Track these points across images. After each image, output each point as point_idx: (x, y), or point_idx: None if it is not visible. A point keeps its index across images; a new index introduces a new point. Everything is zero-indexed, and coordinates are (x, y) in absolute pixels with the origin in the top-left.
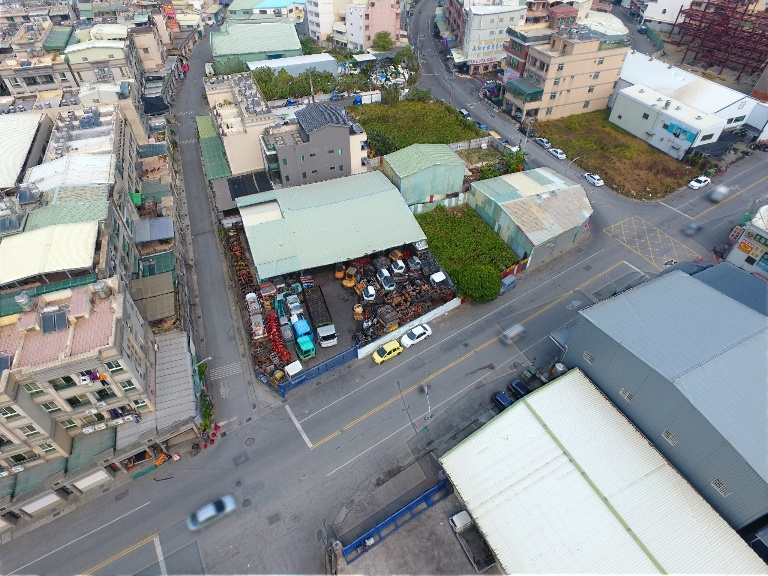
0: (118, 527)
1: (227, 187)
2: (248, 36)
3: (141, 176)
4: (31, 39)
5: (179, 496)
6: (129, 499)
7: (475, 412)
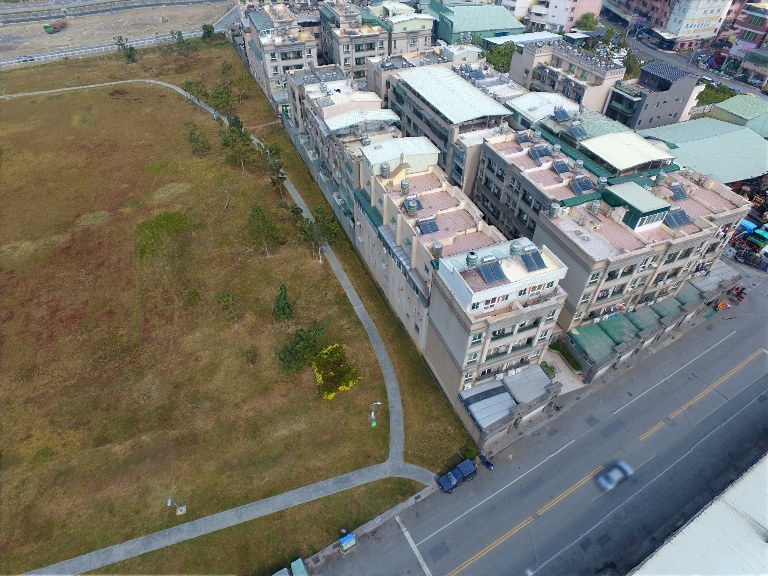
0: (729, 344)
1: None
2: (472, 16)
3: None
4: (353, 12)
5: (754, 327)
6: (718, 329)
7: None
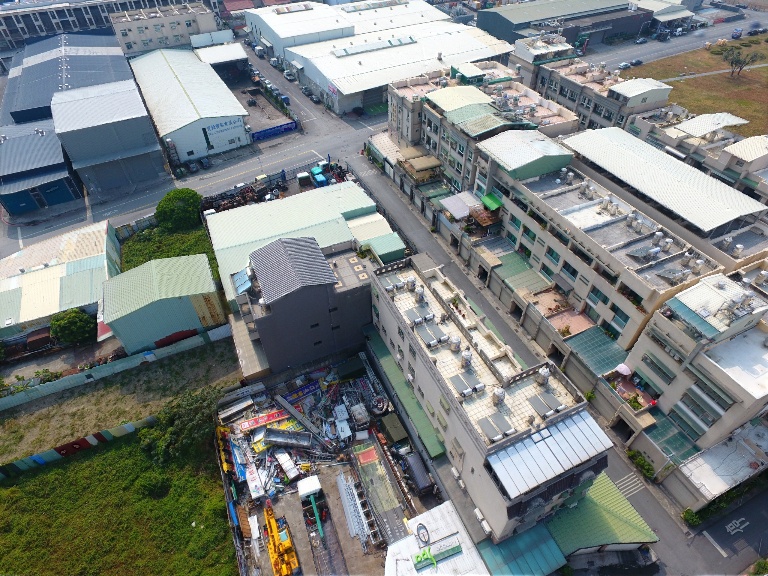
0: None
1: None
2: None
3: (565, 300)
4: None
5: None
6: None
7: None
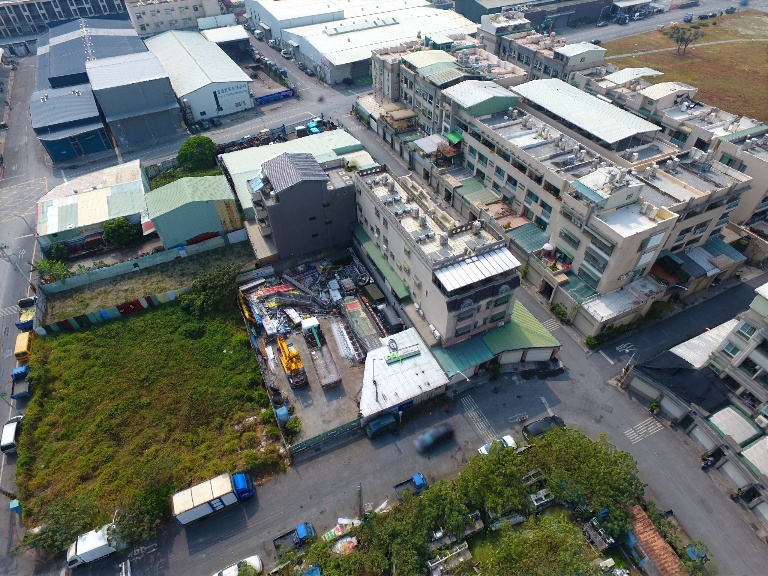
0: None
1: None
2: None
3: (510, 208)
4: None
5: None
6: None
7: None
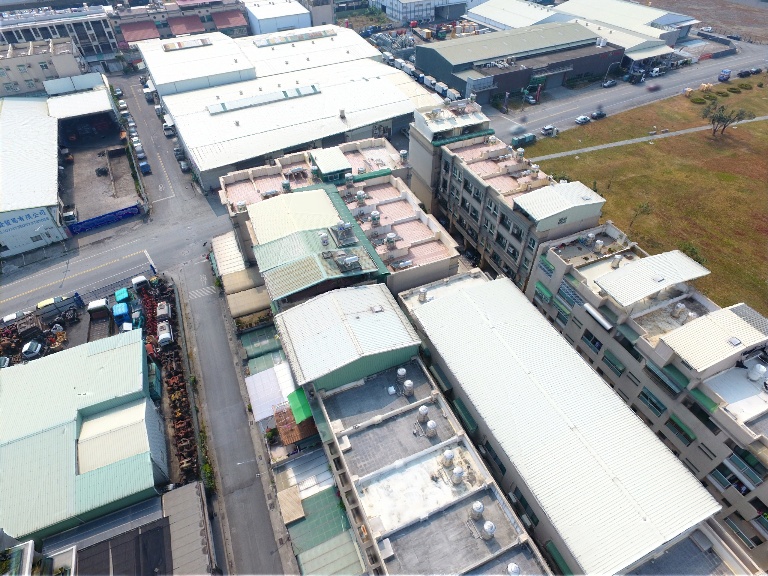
0: None
1: (177, 570)
2: None
3: None
4: None
5: None
6: None
7: (16, 272)
